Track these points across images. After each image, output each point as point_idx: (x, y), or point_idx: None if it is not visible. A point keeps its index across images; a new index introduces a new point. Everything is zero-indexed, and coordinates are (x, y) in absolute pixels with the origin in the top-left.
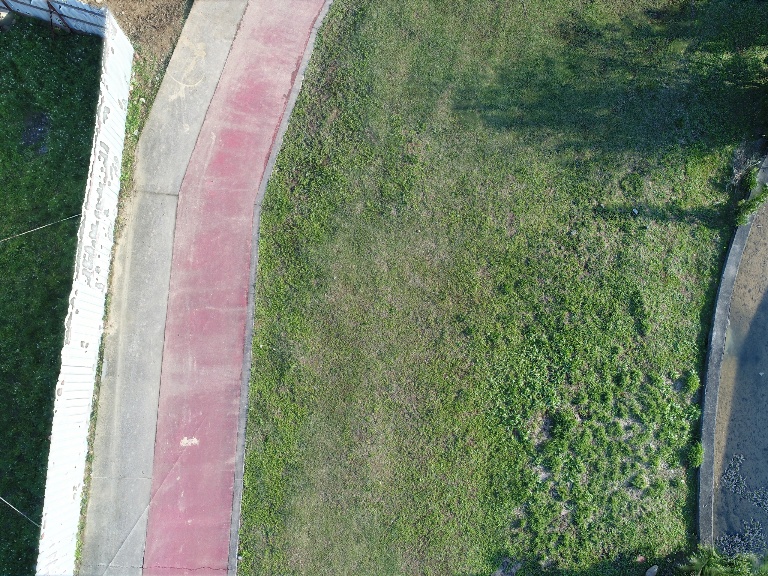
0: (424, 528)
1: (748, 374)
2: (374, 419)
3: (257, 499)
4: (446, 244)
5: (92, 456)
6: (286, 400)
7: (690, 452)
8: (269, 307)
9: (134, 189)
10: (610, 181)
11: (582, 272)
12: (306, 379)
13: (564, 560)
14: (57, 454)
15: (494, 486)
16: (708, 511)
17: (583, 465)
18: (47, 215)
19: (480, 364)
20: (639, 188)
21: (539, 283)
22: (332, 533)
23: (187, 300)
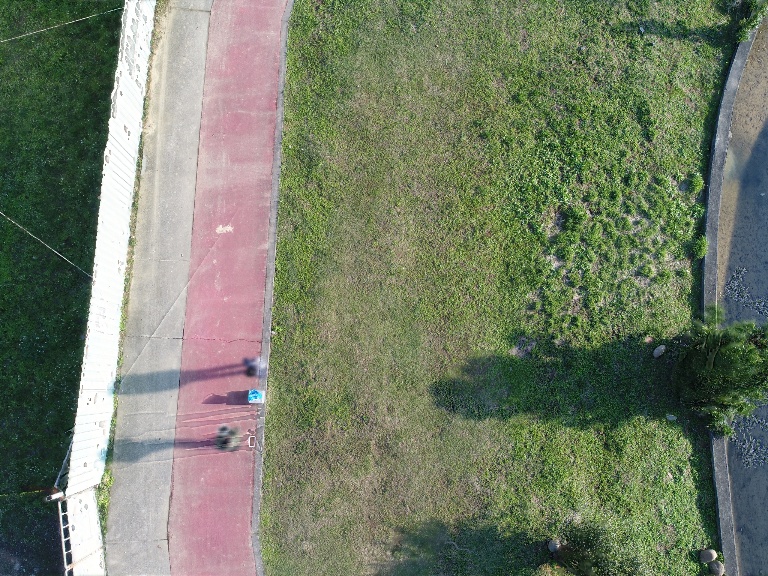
0: (445, 309)
1: (750, 195)
2: (397, 212)
3: (288, 281)
4: (463, 58)
5: (134, 241)
6: (314, 194)
7: (695, 244)
8: (297, 112)
9: (169, 6)
10: (618, 2)
11: (592, 84)
12: (333, 176)
13: (577, 340)
14: (105, 216)
15: (510, 273)
16: (712, 297)
17: (594, 255)
18: (88, 28)
19: (496, 164)
20: (645, 8)
21: (551, 93)
22: (359, 312)
23: (220, 104)
